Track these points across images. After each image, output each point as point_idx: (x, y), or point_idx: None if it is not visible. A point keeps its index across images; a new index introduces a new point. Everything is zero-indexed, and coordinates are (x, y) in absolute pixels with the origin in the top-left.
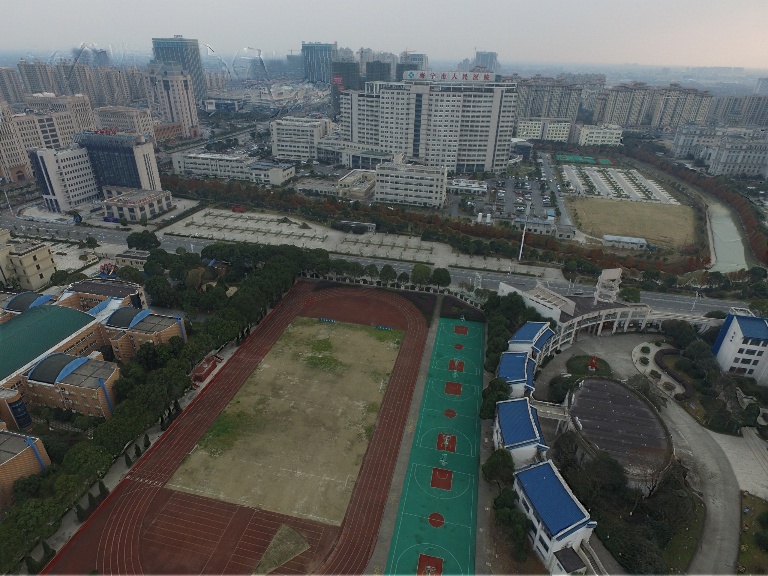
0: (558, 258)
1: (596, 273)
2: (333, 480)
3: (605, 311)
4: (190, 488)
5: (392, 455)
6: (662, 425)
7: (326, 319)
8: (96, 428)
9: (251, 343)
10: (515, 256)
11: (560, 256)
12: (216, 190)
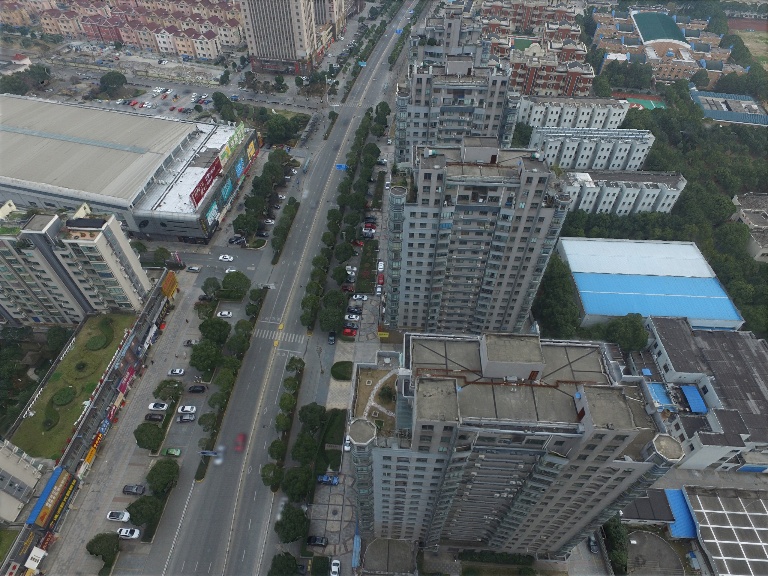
0: None
1: None
2: None
3: None
4: None
5: None
6: None
7: (750, 29)
8: (732, 51)
9: None
10: None
11: None
12: None
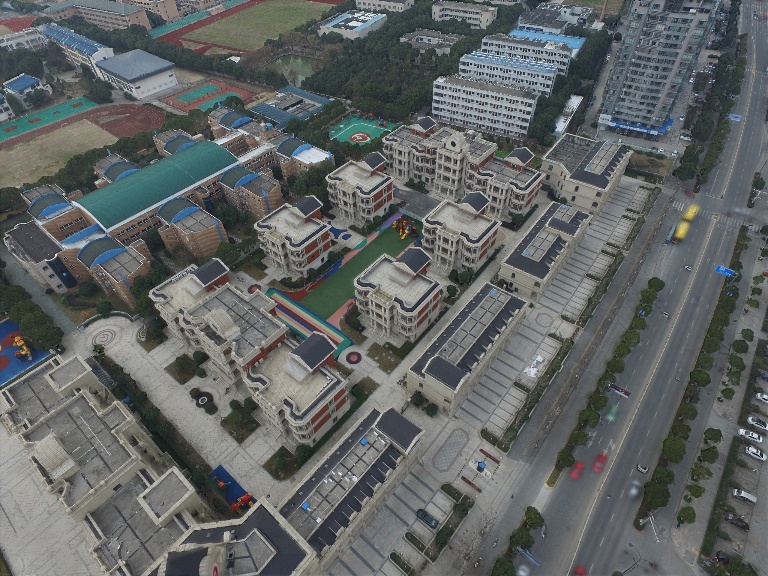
0: None
1: None
2: None
3: None
4: None
5: None
6: None
7: None
8: None
9: None
10: None
11: None
12: None
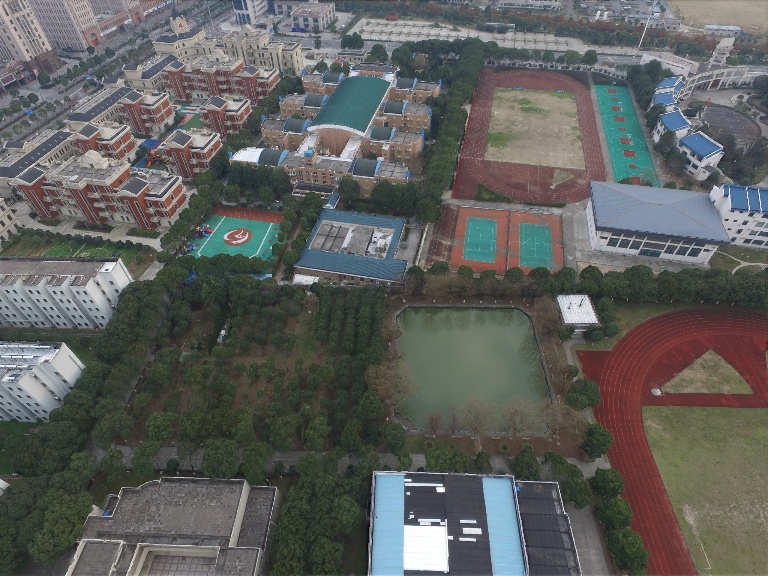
0: (671, 43)
1: (701, 53)
2: (571, 155)
3: (717, 71)
4: (498, 160)
5: (598, 146)
6: (755, 124)
7: (518, 88)
8: None
9: (477, 102)
10: (635, 44)
11: (673, 42)
12: (362, 2)
